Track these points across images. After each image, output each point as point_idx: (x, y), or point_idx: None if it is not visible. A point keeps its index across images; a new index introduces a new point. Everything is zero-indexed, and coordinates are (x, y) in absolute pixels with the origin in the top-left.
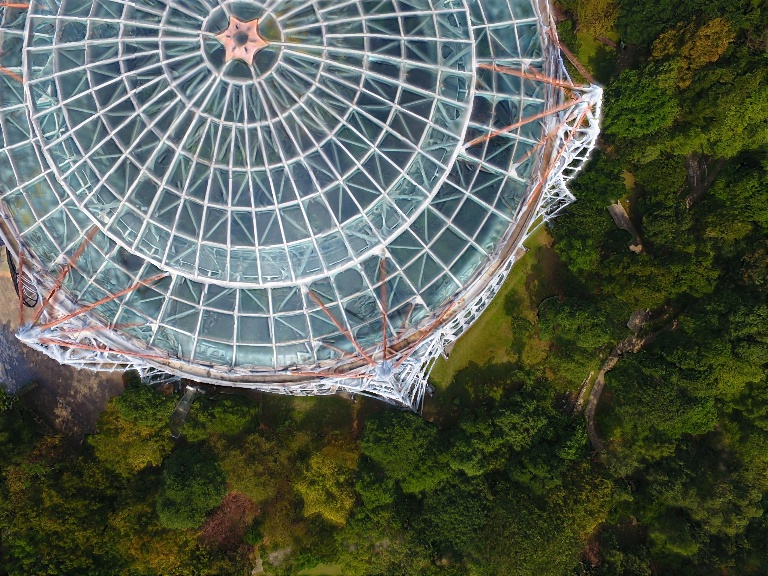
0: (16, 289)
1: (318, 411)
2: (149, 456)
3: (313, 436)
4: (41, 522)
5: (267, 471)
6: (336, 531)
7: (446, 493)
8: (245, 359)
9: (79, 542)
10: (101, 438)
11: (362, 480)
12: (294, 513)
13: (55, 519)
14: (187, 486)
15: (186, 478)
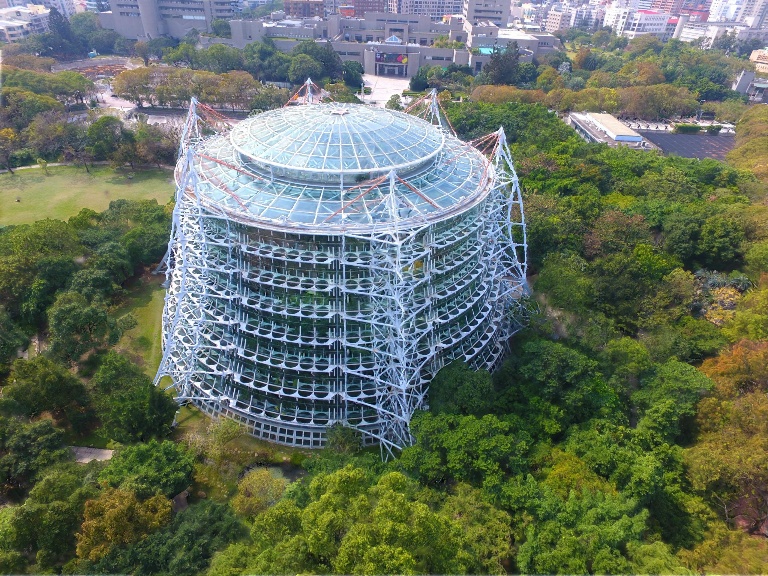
0: None
1: None
2: None
3: None
4: None
5: None
6: None
7: (114, 240)
8: None
9: None
10: None
11: None
12: None
13: None
14: None
15: None
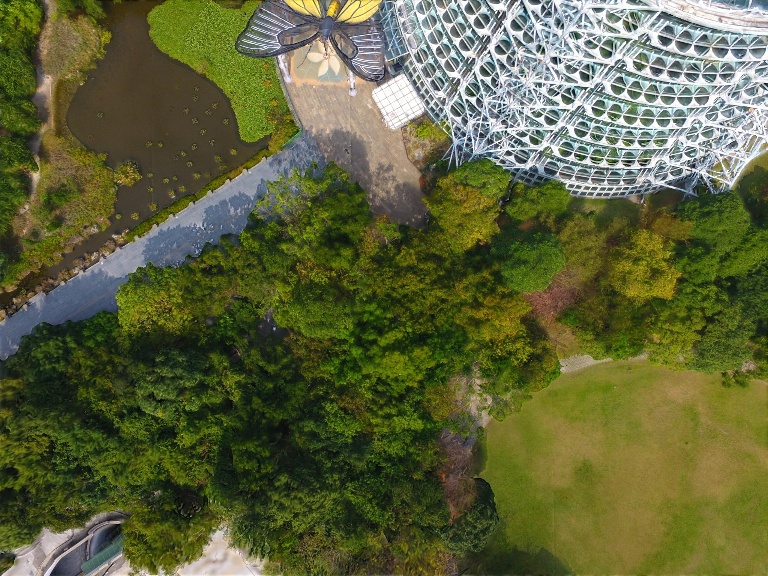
0: (353, 71)
1: (607, 215)
2: (487, 227)
3: (628, 221)
4: (395, 283)
5: (593, 248)
6: (650, 316)
7: (763, 275)
8: (755, 5)
9: (426, 307)
10: (447, 205)
11: (688, 256)
12: (608, 299)
13: (415, 275)
14: (535, 248)
15: (531, 243)
